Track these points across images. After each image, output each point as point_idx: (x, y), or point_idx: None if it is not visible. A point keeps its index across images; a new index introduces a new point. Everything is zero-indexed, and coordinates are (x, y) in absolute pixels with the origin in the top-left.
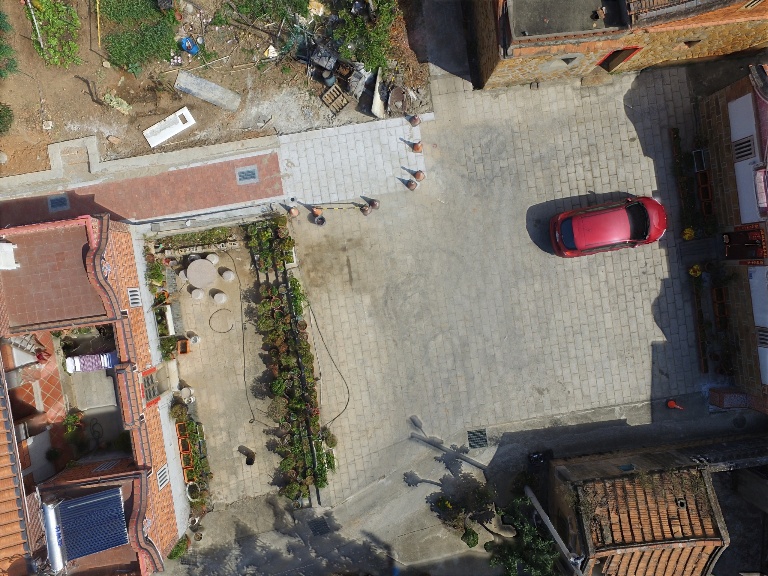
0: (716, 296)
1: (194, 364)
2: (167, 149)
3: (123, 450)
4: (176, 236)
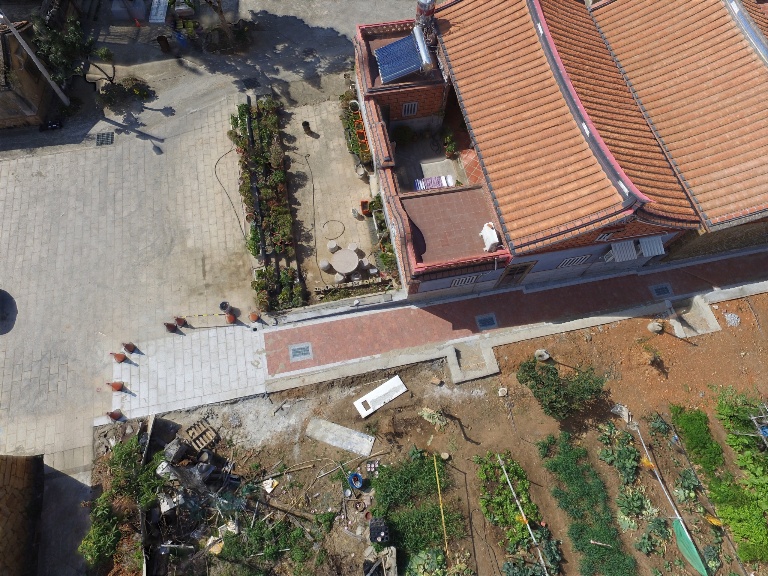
0: None
1: (357, 196)
2: (381, 374)
3: None
4: None
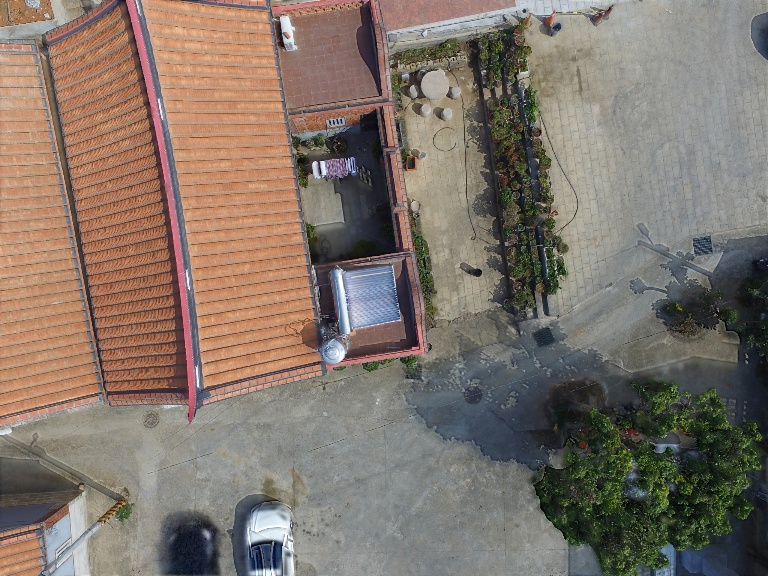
0: None
1: (418, 182)
2: None
3: (361, 257)
4: (406, 52)
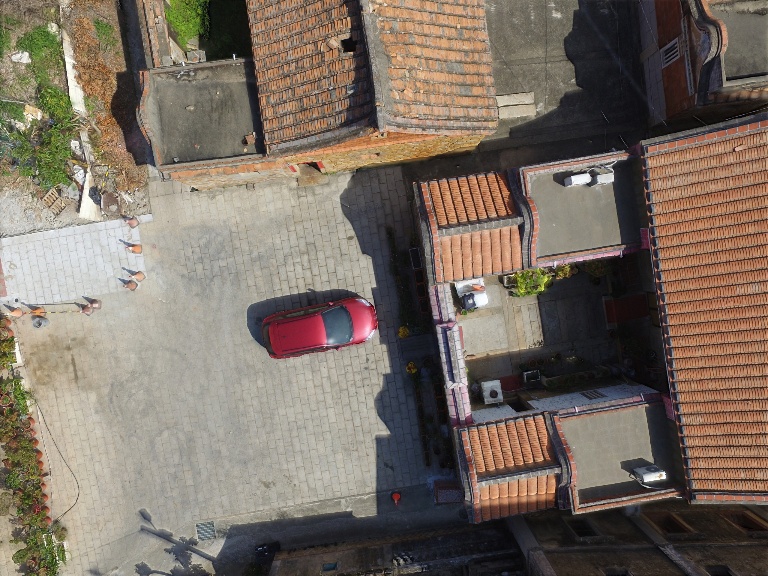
0: (435, 391)
1: None
2: None
3: None
4: None
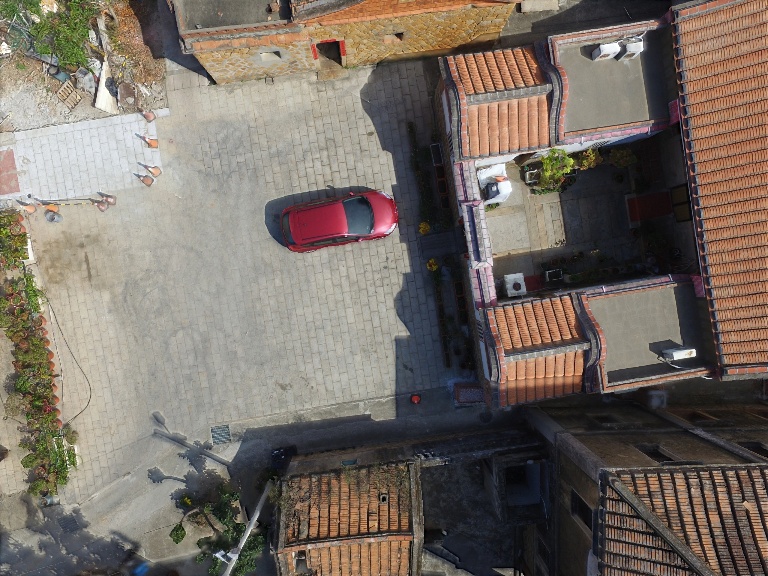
0: (456, 290)
1: None
2: None
3: None
4: None
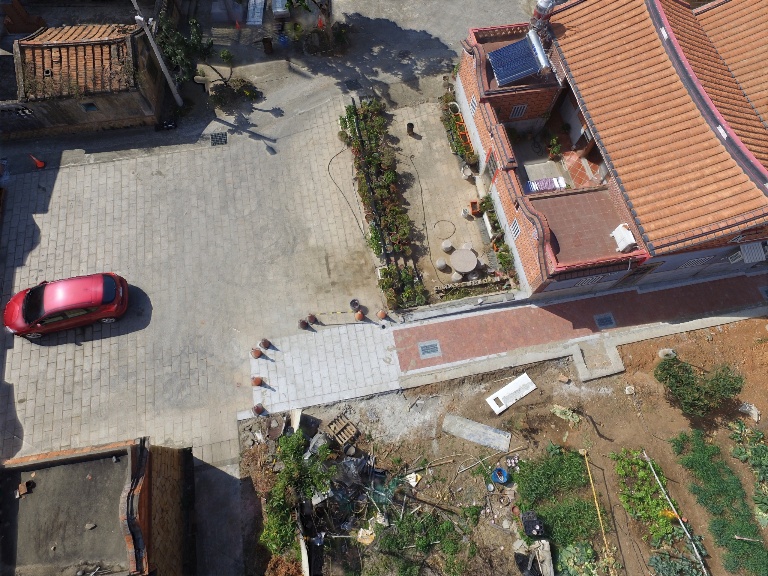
0: None
1: (465, 196)
2: (510, 371)
3: None
4: None
